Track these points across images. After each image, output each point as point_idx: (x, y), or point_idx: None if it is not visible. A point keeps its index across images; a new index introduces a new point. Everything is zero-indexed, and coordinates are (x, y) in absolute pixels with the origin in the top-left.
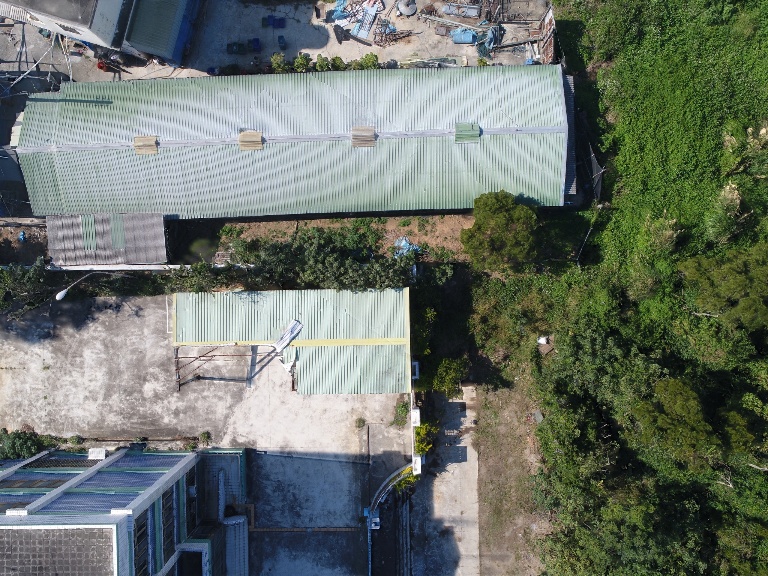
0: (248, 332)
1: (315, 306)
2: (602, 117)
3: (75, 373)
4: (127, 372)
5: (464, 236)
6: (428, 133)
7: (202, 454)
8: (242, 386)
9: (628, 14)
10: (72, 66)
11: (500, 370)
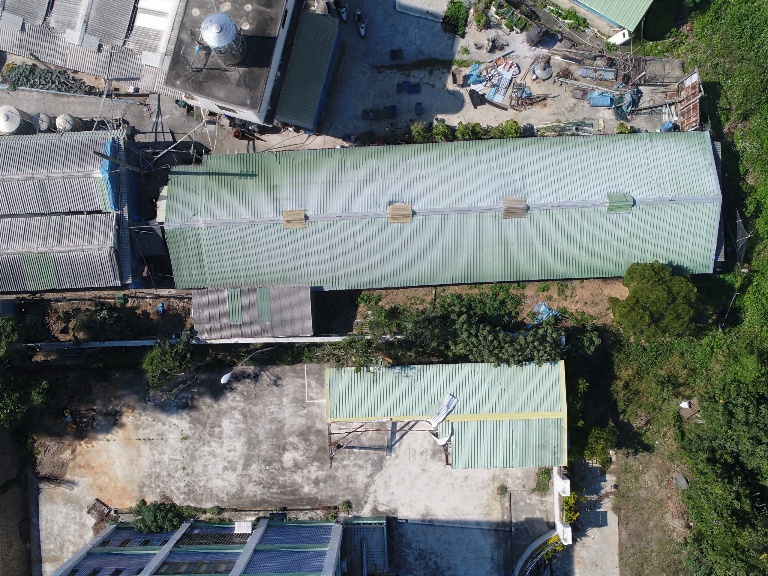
0: (402, 407)
1: (469, 380)
2: (743, 179)
3: (214, 443)
4: (266, 442)
5: (623, 310)
6: (580, 204)
7: (346, 525)
8: (382, 454)
9: (764, 74)
10: (207, 135)
11: (641, 434)
